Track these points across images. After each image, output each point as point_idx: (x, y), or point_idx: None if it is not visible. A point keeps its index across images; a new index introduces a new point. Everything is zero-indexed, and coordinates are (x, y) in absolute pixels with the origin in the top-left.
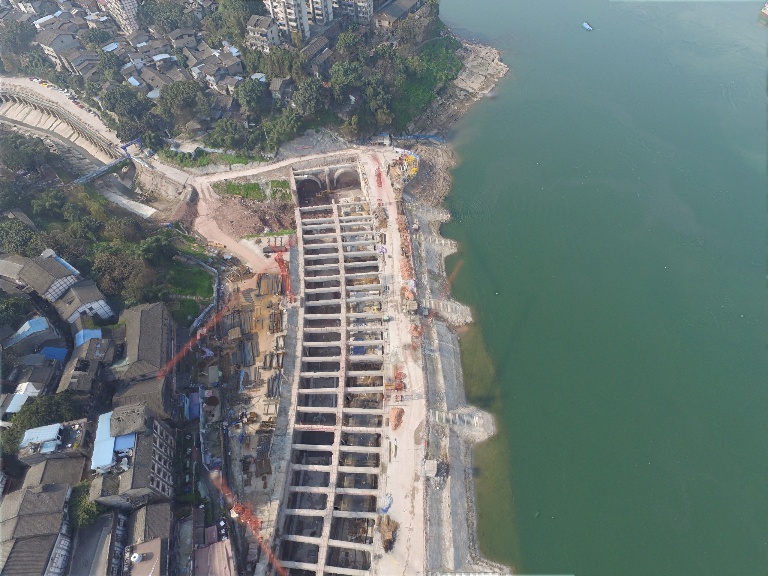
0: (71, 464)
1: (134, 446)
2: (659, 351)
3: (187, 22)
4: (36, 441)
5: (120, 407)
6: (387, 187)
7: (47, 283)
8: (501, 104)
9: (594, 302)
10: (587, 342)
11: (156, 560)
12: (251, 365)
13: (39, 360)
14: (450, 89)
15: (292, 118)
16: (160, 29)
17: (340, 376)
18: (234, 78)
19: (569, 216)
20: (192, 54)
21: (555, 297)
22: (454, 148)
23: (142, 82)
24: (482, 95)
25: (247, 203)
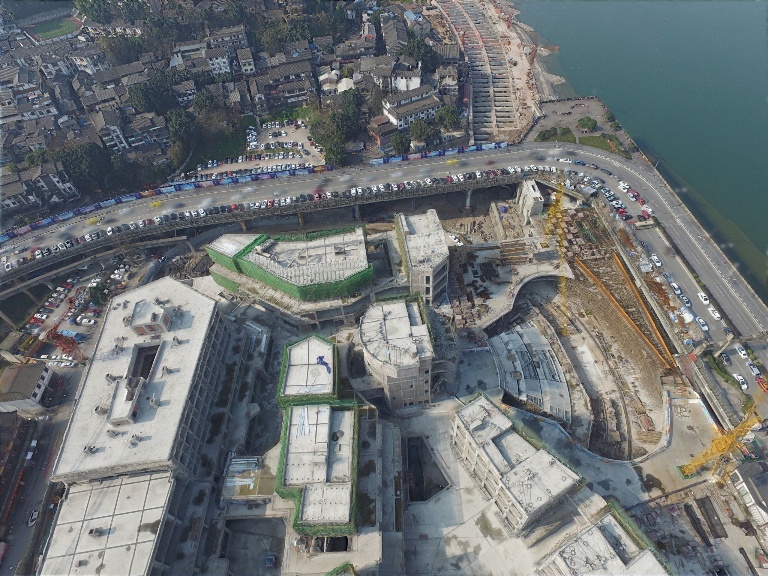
0: None
1: None
2: (626, 31)
3: None
4: None
5: None
6: None
7: None
8: None
9: (594, 22)
10: (591, 31)
11: None
12: (438, 35)
13: (368, 8)
14: None
15: None
16: None
17: (479, 37)
18: None
19: None
20: None
21: (574, 22)
22: None
23: None
24: None
25: None
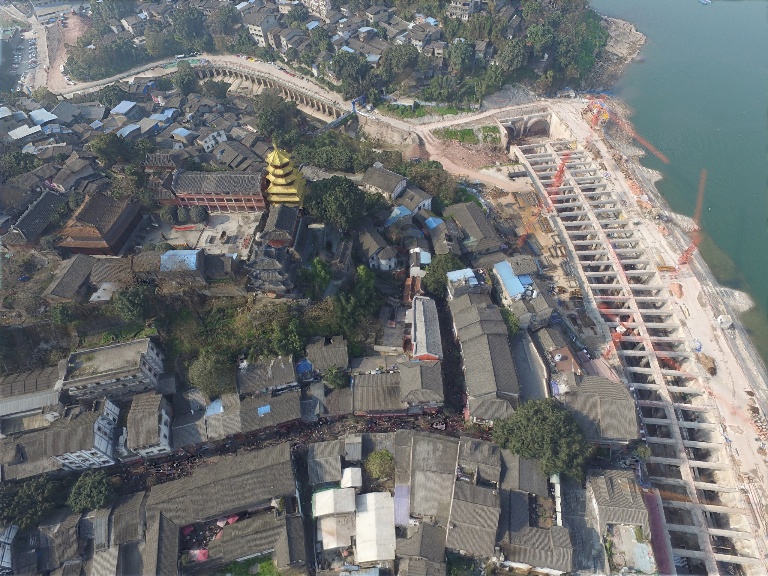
0: (483, 298)
1: (533, 282)
2: None
3: (378, 0)
4: (462, 278)
5: (510, 258)
6: (587, 129)
7: (393, 184)
8: (651, 65)
9: None
10: None
11: (572, 360)
12: (540, 255)
13: (418, 233)
14: (604, 54)
15: (498, 73)
16: (354, 7)
17: (615, 263)
18: (440, 42)
19: (752, 150)
20: (389, 26)
21: (765, 210)
22: (624, 101)
23: (356, 50)
24: (631, 59)
25: (465, 146)
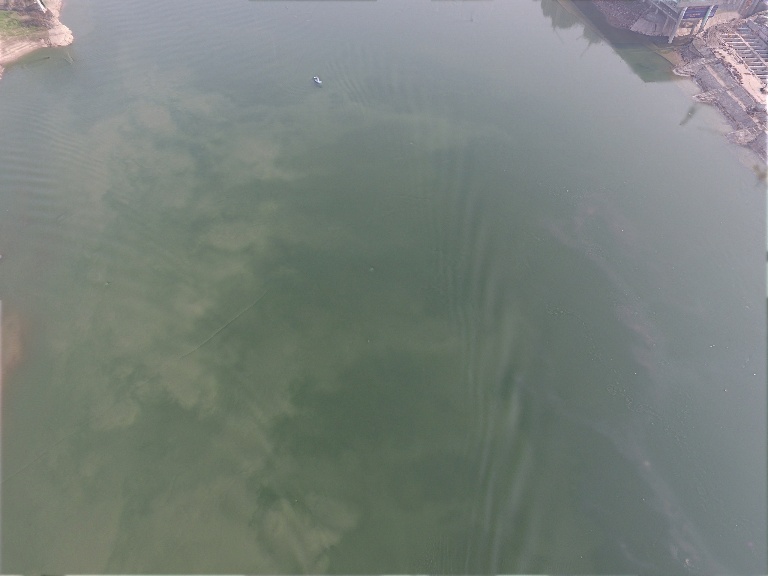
0: None
1: None
2: (630, 173)
3: None
4: None
5: None
6: None
7: None
8: None
9: (683, 200)
10: (682, 176)
11: None
12: None
13: None
14: None
15: None
16: None
17: None
18: None
19: (731, 279)
20: None
21: (716, 203)
22: None
23: None
24: None
25: None
